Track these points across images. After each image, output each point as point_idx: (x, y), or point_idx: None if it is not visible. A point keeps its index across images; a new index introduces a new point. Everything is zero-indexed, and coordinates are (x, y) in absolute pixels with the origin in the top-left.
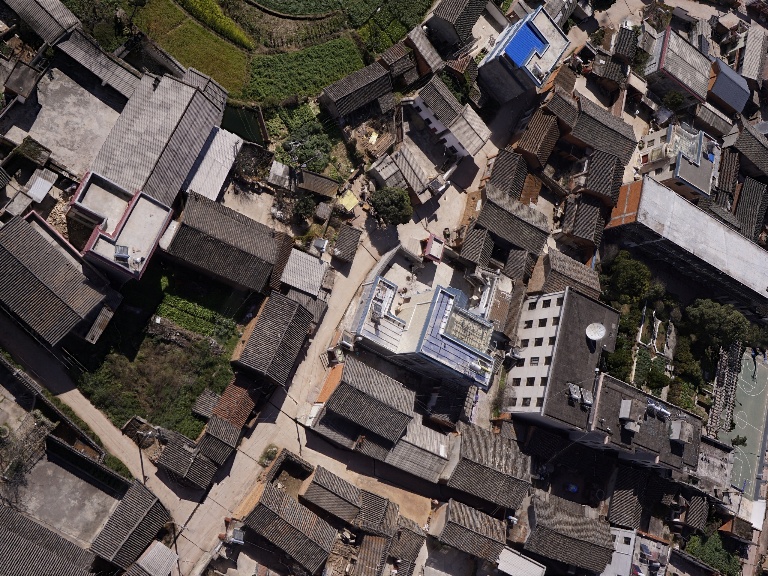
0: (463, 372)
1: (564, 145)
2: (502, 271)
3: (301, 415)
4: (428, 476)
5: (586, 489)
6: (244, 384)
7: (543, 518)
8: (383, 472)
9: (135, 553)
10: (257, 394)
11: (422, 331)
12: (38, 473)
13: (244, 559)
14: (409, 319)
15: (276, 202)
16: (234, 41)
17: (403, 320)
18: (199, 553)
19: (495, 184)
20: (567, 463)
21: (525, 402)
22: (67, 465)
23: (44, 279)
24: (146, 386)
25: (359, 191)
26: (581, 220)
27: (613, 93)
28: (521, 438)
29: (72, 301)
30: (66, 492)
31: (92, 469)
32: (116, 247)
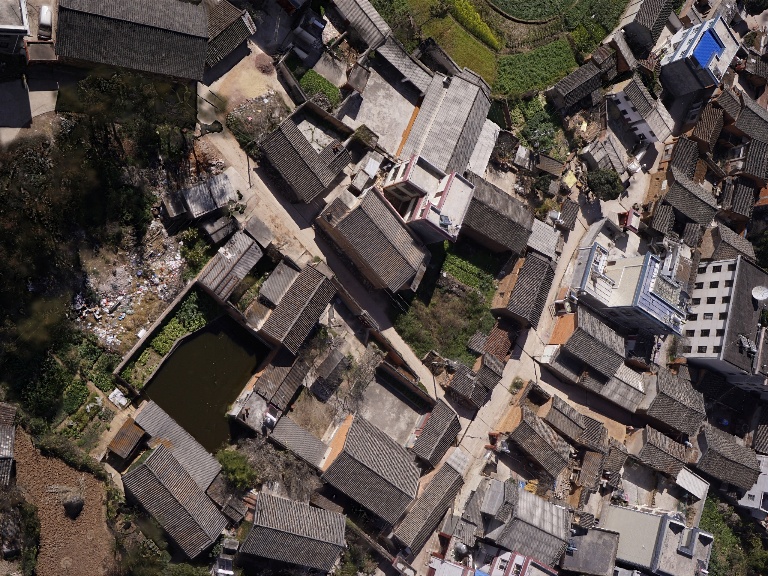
0: (665, 323)
1: (724, 134)
2: (684, 241)
3: (537, 354)
4: (629, 406)
5: (732, 424)
6: (505, 327)
7: (712, 444)
8: (593, 402)
9: (440, 455)
10: (513, 336)
11: (638, 289)
12: (370, 391)
13: (501, 466)
14: (618, 279)
15: (519, 180)
16: (486, 43)
17: (612, 279)
18: (472, 459)
19: (676, 167)
20: (723, 401)
21: (701, 349)
22: (388, 386)
23: (391, 240)
24: (437, 327)
25: (573, 171)
26: (739, 199)
27: (758, 88)
28: (694, 379)
29: (408, 258)
30: (388, 407)
31: (405, 390)
32: (441, 216)
